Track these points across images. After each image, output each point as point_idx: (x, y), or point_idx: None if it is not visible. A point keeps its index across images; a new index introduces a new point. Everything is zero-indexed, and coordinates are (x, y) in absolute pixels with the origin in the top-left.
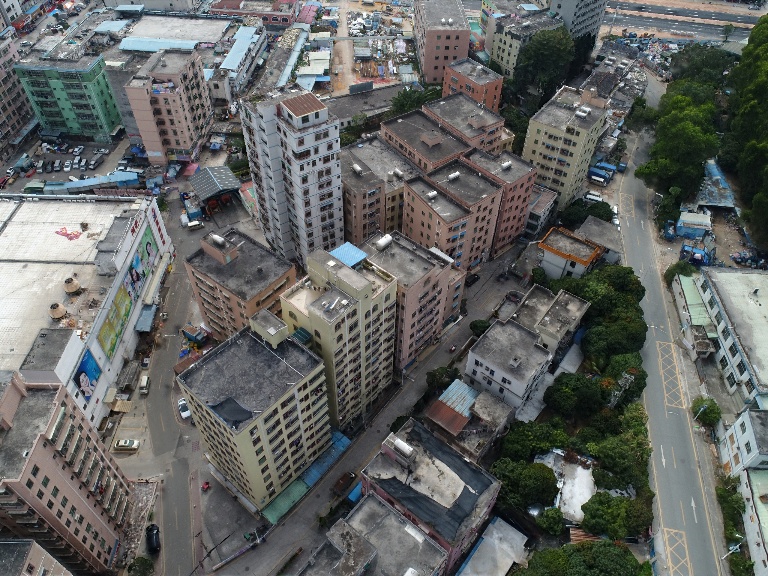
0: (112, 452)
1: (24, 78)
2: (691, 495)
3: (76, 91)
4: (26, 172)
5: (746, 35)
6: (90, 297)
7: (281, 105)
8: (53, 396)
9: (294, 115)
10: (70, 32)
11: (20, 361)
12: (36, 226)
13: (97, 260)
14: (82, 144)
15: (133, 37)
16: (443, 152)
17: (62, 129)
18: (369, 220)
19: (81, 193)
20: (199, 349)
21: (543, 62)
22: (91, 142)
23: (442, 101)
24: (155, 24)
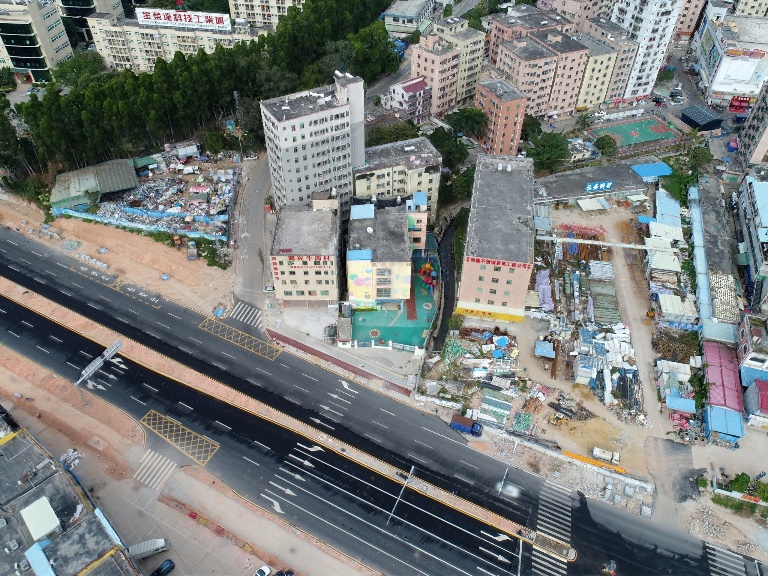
0: None
1: None
2: (469, 3)
3: None
4: None
5: (5, 249)
6: None
7: None
8: None
9: None
10: None
11: None
12: None
13: None
14: None
15: None
16: (547, 35)
17: None
18: None
19: None
20: None
21: None
22: None
23: (541, 60)
24: None
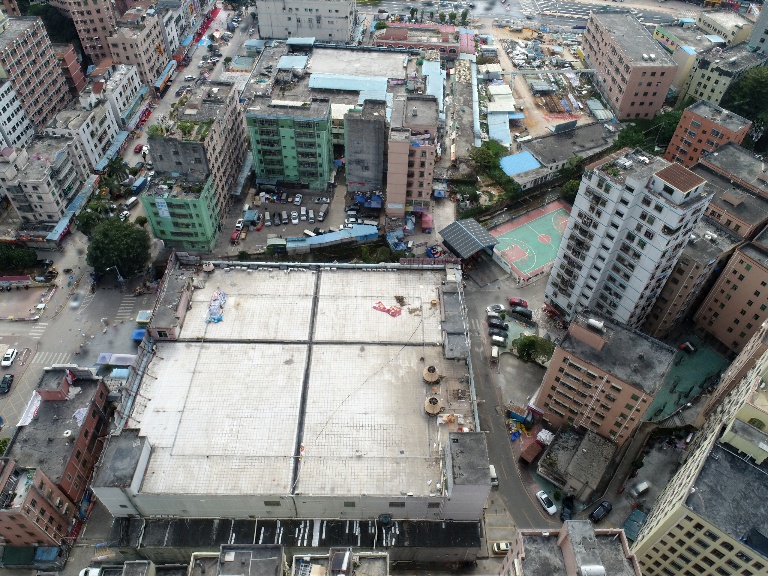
0: (492, 556)
1: (254, 127)
2: None
3: (307, 140)
4: (255, 225)
5: None
6: (451, 386)
7: (654, 178)
8: (614, 544)
9: (680, 191)
10: (253, 69)
11: (418, 466)
12: (349, 300)
13: (451, 344)
14: (299, 192)
15: (318, 74)
16: (752, 212)
17: (278, 177)
18: (694, 289)
19: (322, 249)
20: (528, 431)
21: (757, 100)
22: (305, 189)
23: (715, 152)
24: (330, 58)
